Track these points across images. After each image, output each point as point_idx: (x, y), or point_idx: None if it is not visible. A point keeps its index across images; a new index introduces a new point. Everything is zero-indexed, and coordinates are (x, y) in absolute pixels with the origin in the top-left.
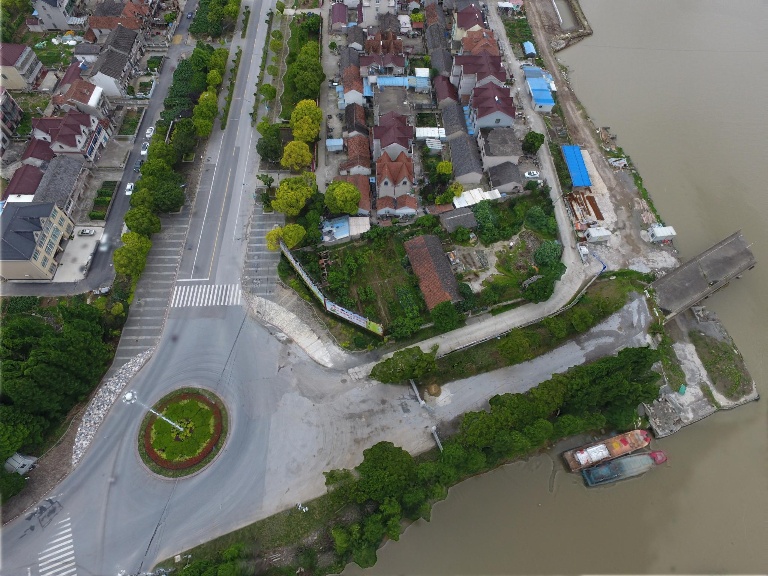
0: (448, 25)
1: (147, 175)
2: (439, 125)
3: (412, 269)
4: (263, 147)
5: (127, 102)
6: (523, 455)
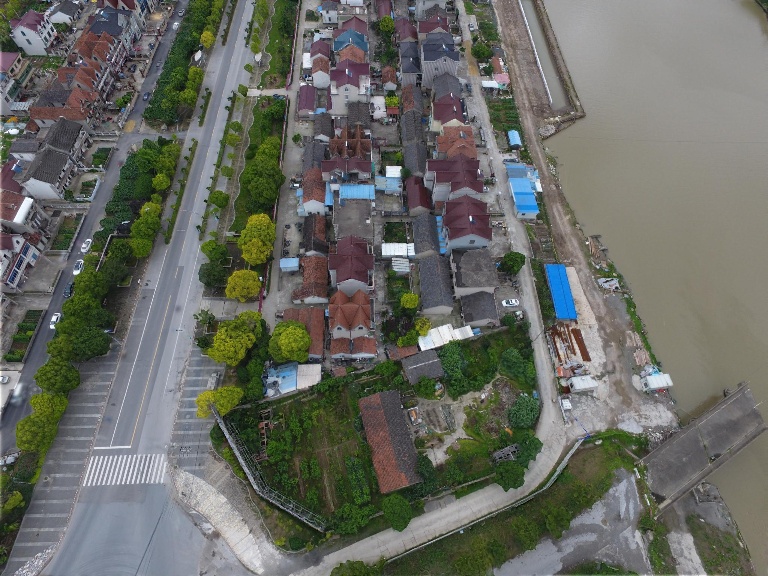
0: (426, 111)
1: (69, 315)
2: (409, 238)
3: (366, 434)
4: (206, 275)
5: (65, 206)
6: None
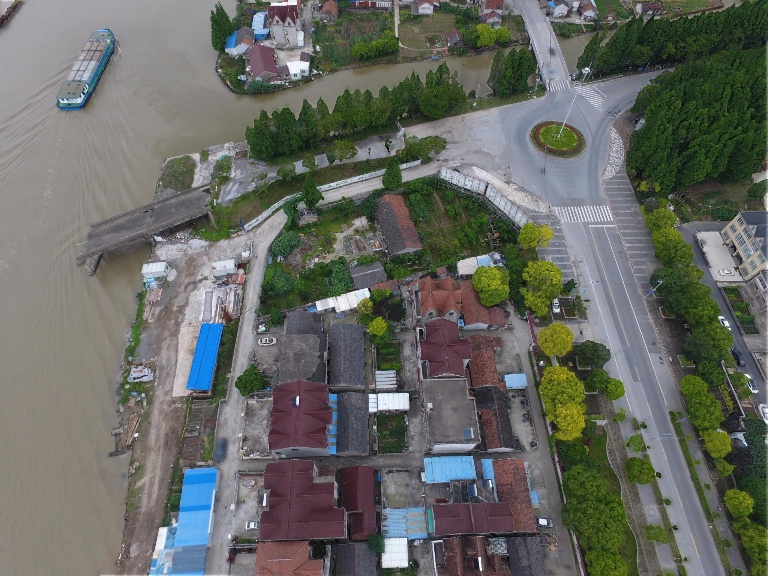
0: None
1: None
2: (374, 427)
3: None
4: None
5: None
6: None
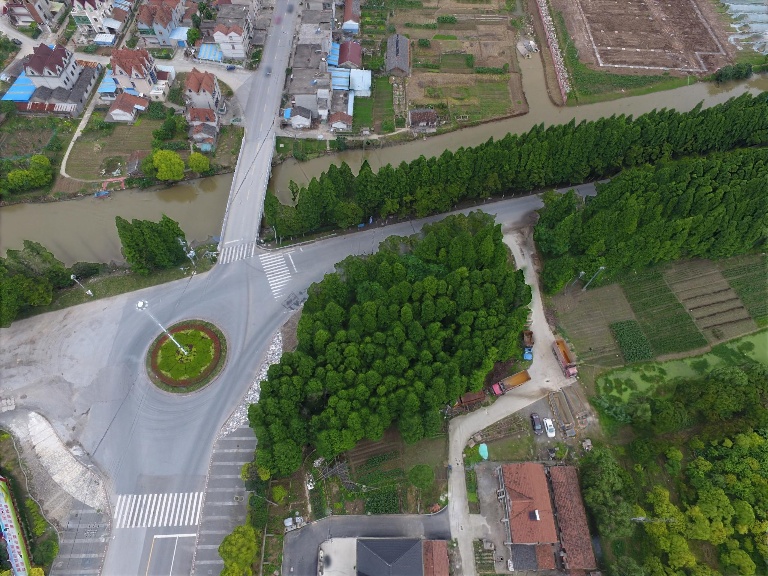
0: None
1: None
2: None
3: None
4: None
5: None
6: None
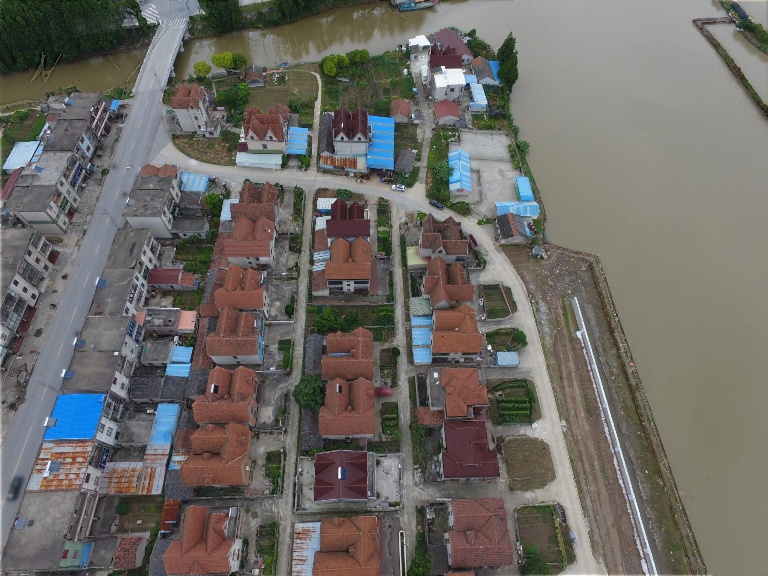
0: None
1: None
2: None
3: None
4: None
5: None
6: (370, 0)
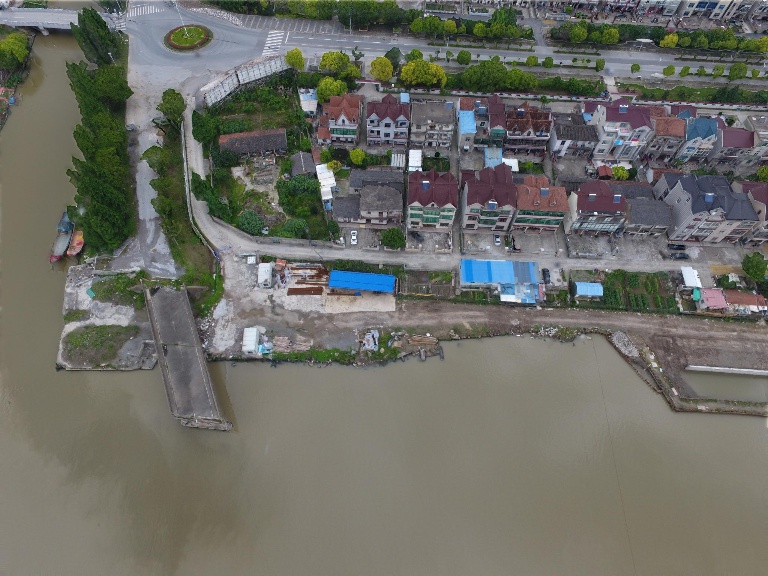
0: None
1: None
2: None
3: None
4: (390, 51)
5: None
6: None
